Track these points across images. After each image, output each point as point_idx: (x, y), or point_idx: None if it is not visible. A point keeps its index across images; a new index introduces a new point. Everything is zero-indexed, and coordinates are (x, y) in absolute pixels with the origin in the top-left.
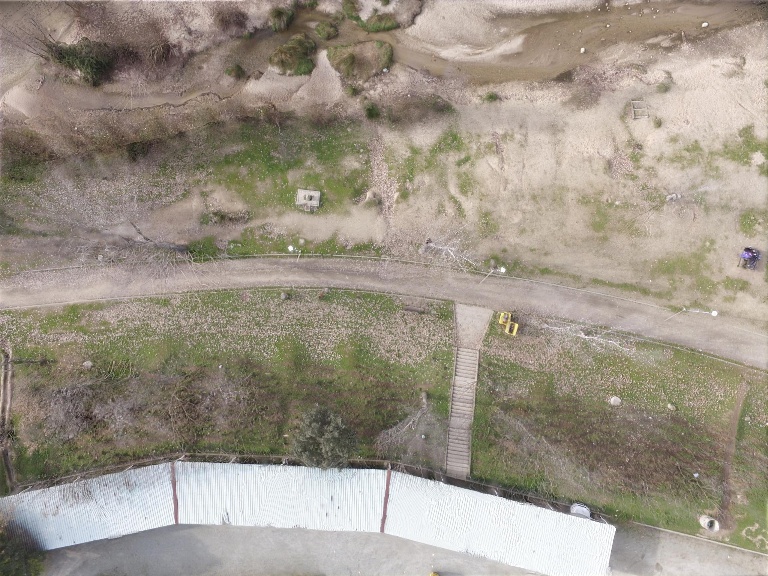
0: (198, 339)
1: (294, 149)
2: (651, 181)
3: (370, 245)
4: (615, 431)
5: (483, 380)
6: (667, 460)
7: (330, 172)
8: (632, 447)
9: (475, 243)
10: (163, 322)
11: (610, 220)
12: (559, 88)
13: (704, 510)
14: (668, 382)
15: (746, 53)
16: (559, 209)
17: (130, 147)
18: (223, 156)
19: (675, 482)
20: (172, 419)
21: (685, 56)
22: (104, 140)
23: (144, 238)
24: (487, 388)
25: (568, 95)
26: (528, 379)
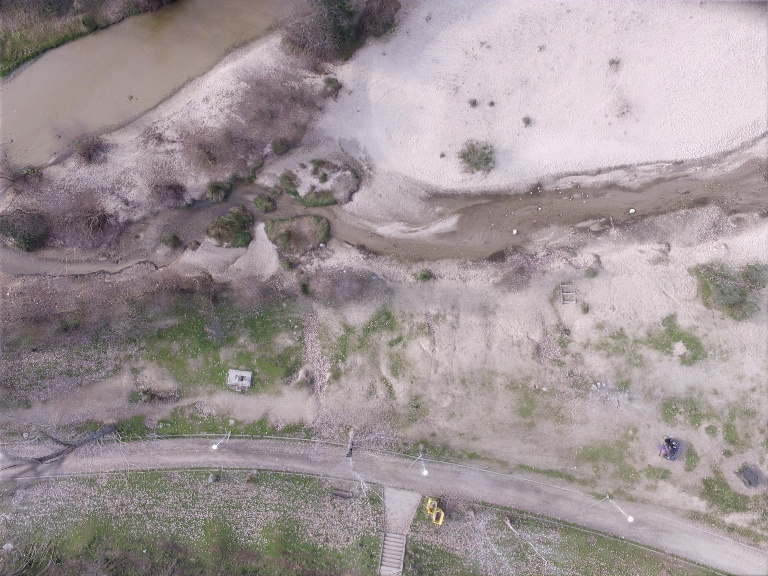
0: (124, 520)
1: (228, 325)
2: (577, 368)
3: (301, 426)
4: None
5: (408, 570)
6: None
7: (263, 351)
8: None
9: (405, 426)
10: (88, 503)
11: (537, 406)
12: (492, 268)
13: None
14: (591, 569)
15: (671, 240)
16: (488, 394)
17: (62, 317)
18: (156, 330)
19: None
20: None
21: (613, 240)
22: (36, 307)
23: None
24: None
25: (500, 276)
26: (454, 566)
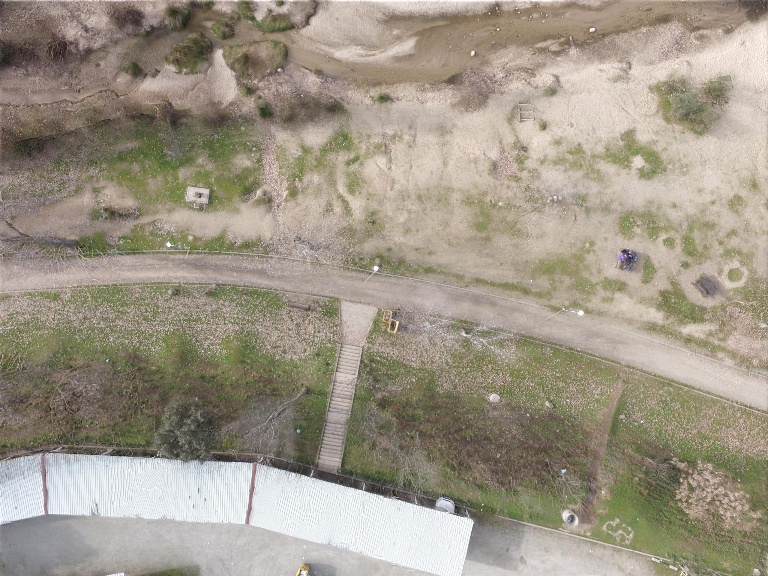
0: (87, 333)
1: (187, 147)
2: (534, 183)
3: (258, 242)
4: (490, 427)
5: (364, 376)
6: (538, 456)
7: (221, 170)
8: (505, 443)
9: (361, 242)
10: (53, 316)
11: (493, 221)
12: (450, 90)
13: (567, 505)
14: (547, 380)
15: (632, 58)
16: (444, 209)
17: (26, 143)
18: (117, 153)
19: (542, 477)
20: (52, 412)
21: (573, 60)
22: (1, 135)
23: (20, 233)
24: (367, 384)
25: (458, 97)
26: (409, 376)
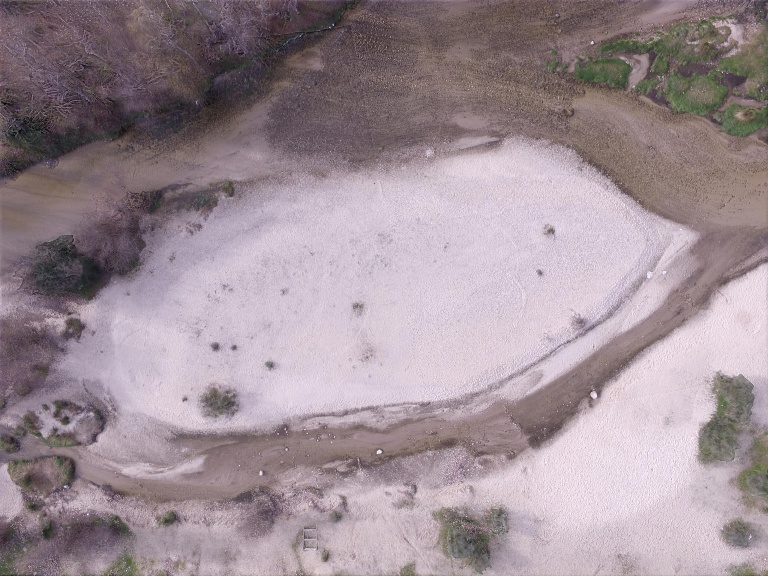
0: None
1: None
2: None
3: None
4: None
5: None
6: None
7: None
8: None
9: None
10: None
11: None
12: (238, 509)
13: None
14: None
15: (418, 481)
16: None
17: None
18: None
19: None
20: None
21: (360, 482)
22: None
23: None
24: None
25: (245, 519)
26: None
